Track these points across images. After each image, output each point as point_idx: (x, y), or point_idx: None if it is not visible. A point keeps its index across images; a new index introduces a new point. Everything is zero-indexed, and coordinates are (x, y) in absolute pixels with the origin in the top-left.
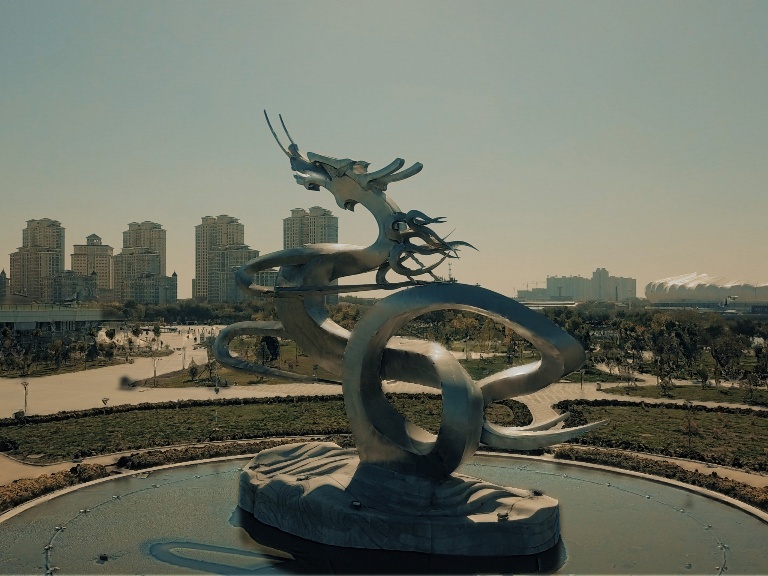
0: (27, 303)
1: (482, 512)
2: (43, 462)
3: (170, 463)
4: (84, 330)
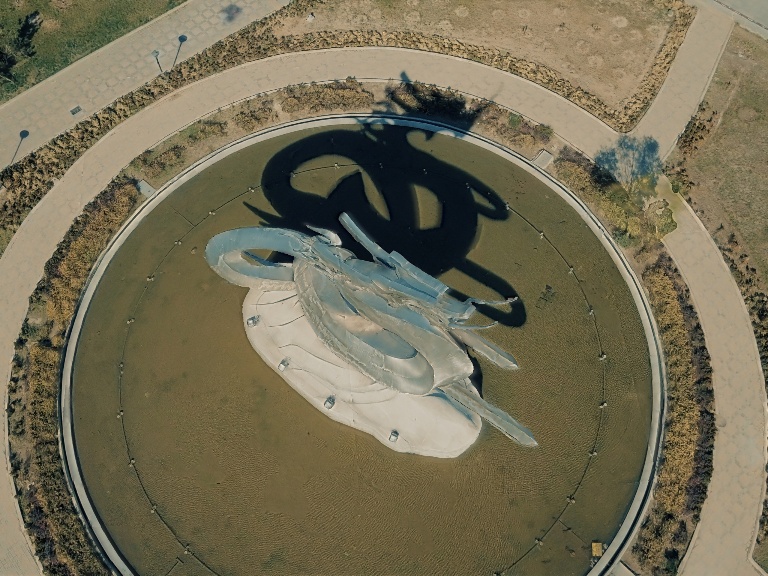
0: None
1: None
2: None
3: None
4: None
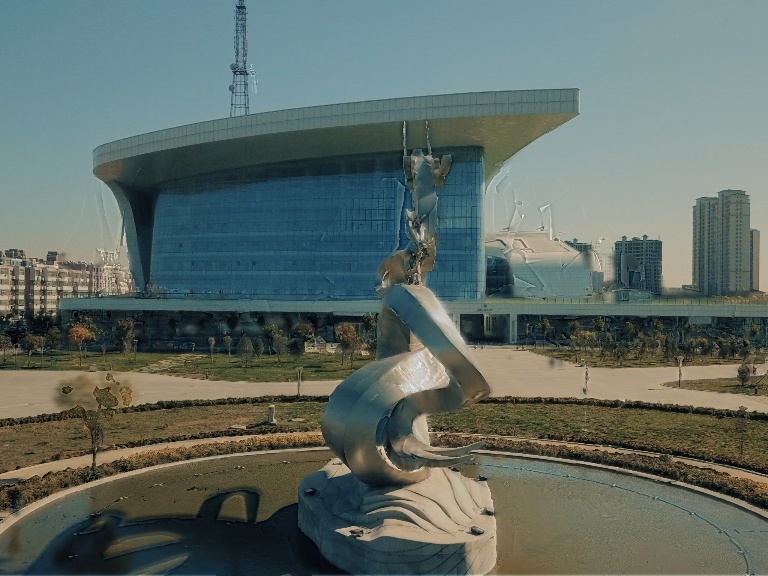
0: (702, 298)
1: (365, 526)
2: None
3: None
4: (746, 326)
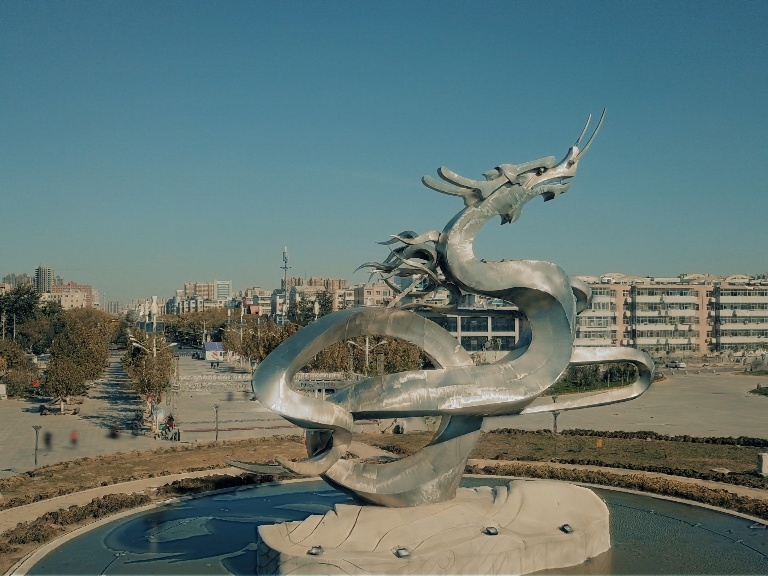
0: None
1: None
2: None
3: None
4: None
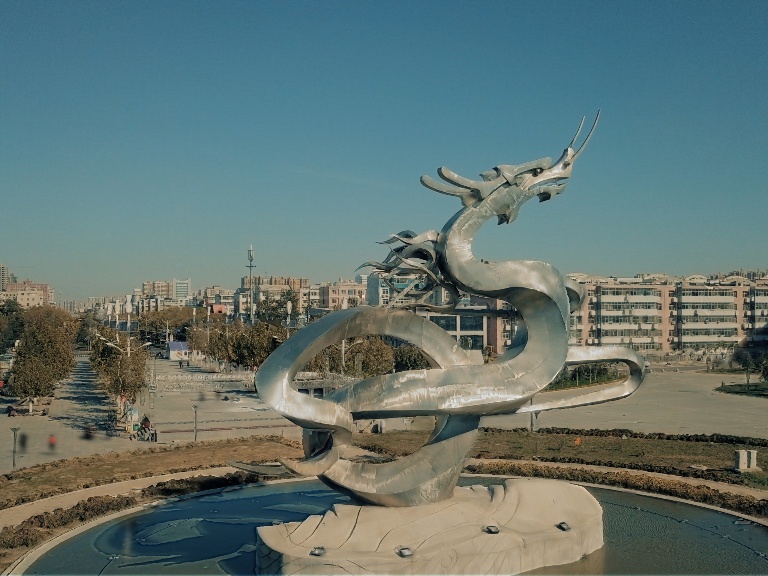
0: None
1: None
2: None
3: None
4: None
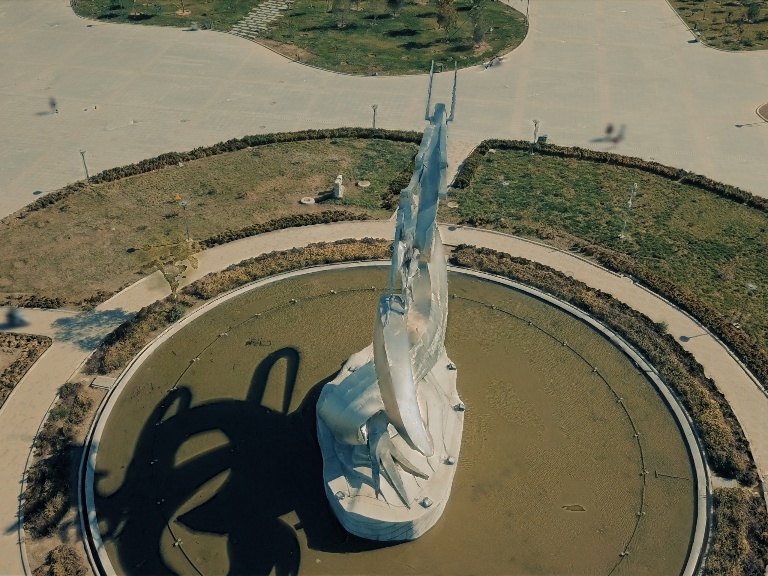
0: None
1: (350, 481)
2: (439, 216)
3: (477, 268)
4: None
